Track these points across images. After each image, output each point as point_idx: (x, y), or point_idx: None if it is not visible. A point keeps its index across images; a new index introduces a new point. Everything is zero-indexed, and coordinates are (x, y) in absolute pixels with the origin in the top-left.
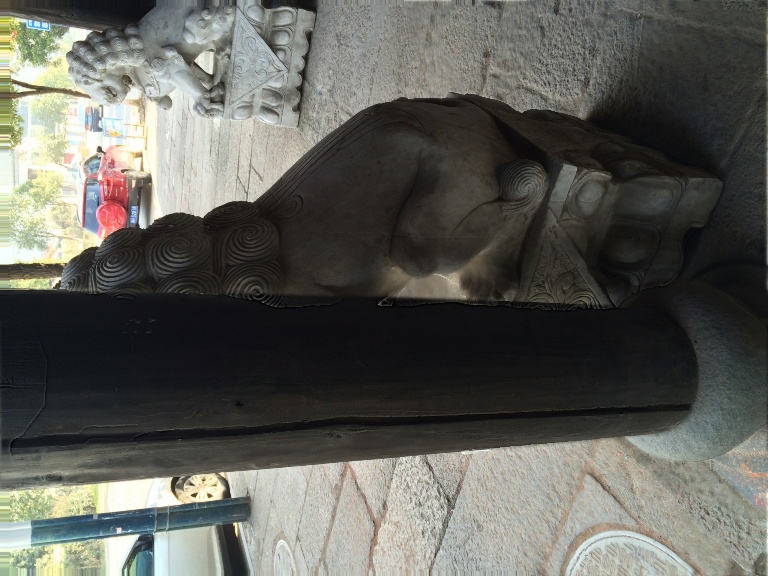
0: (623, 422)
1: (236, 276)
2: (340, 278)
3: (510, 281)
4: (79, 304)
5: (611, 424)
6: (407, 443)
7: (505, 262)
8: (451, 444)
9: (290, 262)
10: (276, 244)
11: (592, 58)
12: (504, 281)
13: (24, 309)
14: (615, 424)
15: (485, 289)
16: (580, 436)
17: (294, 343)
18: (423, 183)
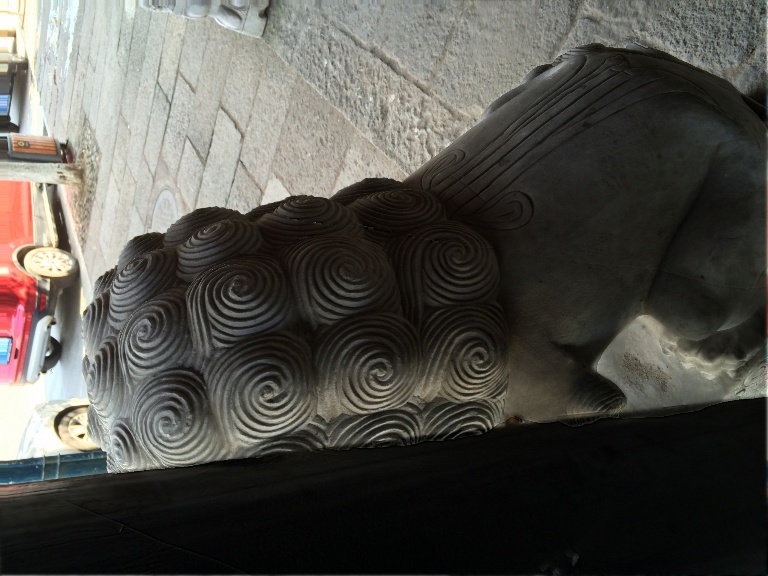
0: None
1: (445, 328)
2: (582, 333)
3: (762, 336)
4: (421, 528)
5: None
6: None
7: (760, 310)
8: None
9: (519, 305)
10: (495, 273)
11: (765, 20)
12: (754, 336)
13: (322, 570)
14: None
15: (719, 342)
16: None
17: (759, 560)
18: (719, 197)
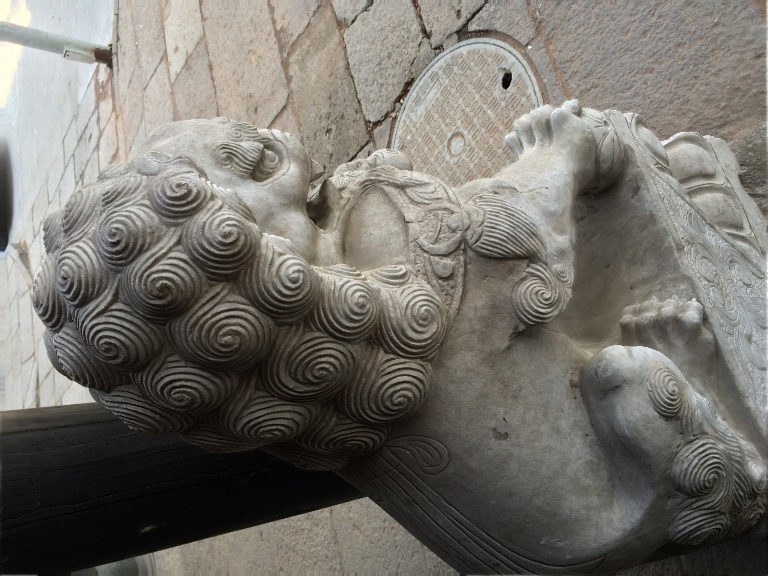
0: None
1: None
2: None
3: None
4: None
5: None
6: None
7: None
8: None
9: None
10: None
11: None
12: None
13: None
14: None
15: None
16: None
17: None
18: None
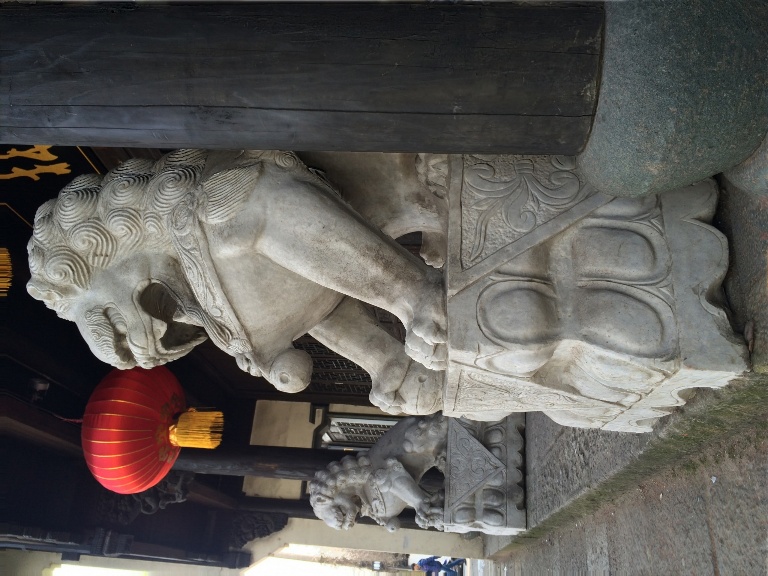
0: (483, 20)
1: None
2: None
3: None
4: None
5: (464, 22)
6: (187, 29)
7: None
8: (243, 40)
9: None
10: None
11: None
12: None
13: None
14: (471, 22)
15: None
16: (429, 46)
17: None
18: None
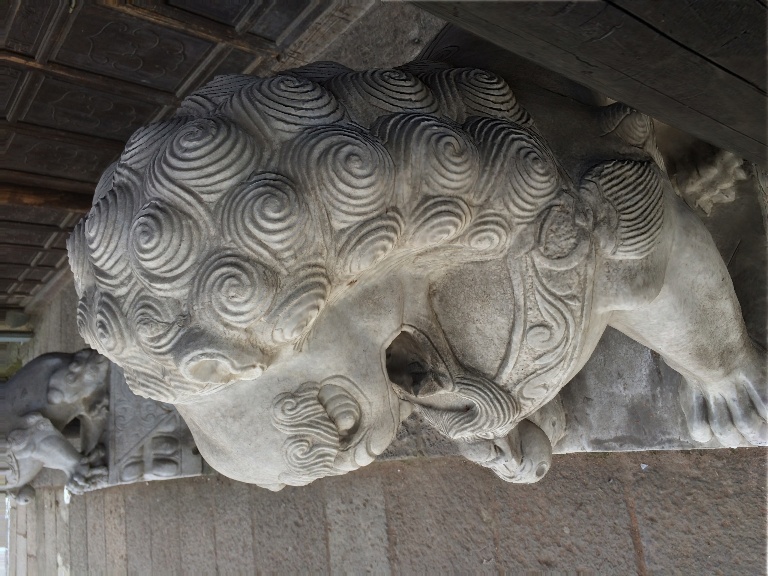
0: None
1: None
2: (565, 89)
3: None
4: None
5: None
6: None
7: None
8: None
9: None
10: None
11: None
12: None
13: None
14: None
15: (704, 150)
16: None
17: None
18: None
